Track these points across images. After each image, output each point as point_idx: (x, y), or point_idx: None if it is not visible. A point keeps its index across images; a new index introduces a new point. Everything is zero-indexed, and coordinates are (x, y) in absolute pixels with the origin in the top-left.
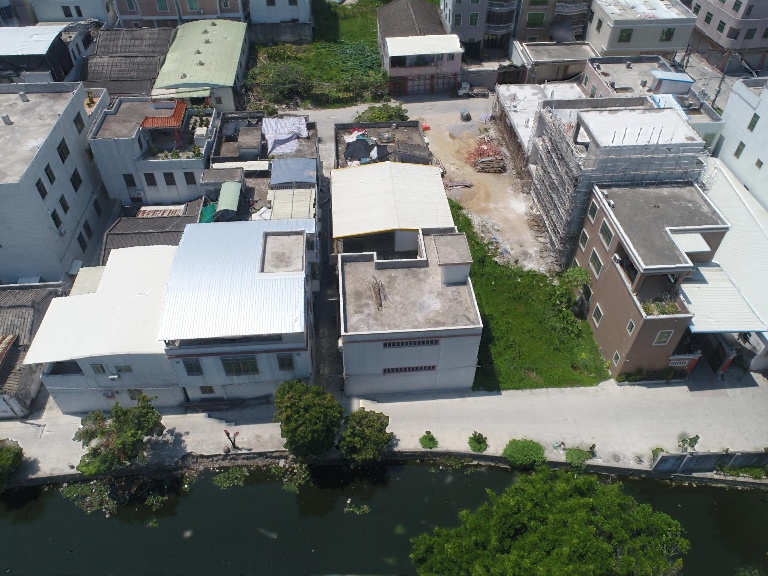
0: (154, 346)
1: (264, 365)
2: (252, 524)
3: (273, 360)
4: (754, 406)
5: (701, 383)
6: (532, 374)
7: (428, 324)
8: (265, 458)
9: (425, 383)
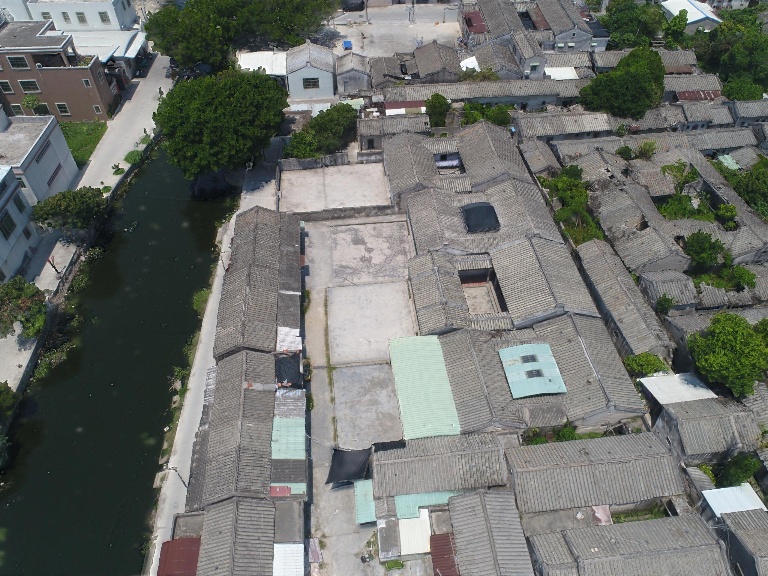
0: None
1: (13, 216)
2: (119, 271)
3: (14, 207)
4: (150, 85)
5: (128, 96)
6: (84, 148)
7: (34, 139)
8: (74, 265)
9: (65, 182)
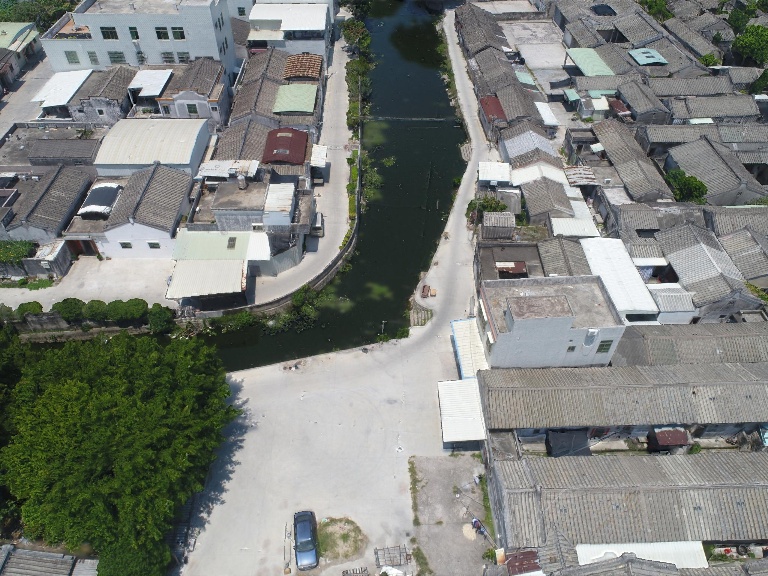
0: (324, 5)
1: None
2: None
3: None
4: None
5: None
6: None
7: None
8: None
9: None
